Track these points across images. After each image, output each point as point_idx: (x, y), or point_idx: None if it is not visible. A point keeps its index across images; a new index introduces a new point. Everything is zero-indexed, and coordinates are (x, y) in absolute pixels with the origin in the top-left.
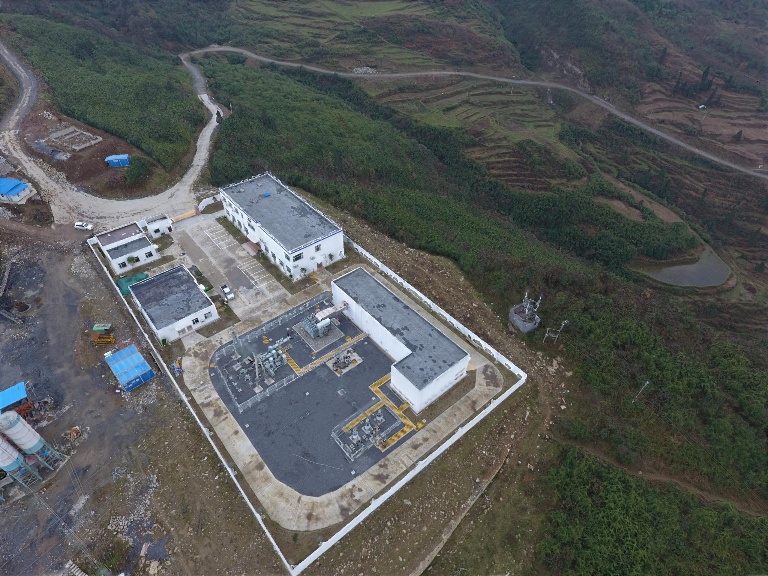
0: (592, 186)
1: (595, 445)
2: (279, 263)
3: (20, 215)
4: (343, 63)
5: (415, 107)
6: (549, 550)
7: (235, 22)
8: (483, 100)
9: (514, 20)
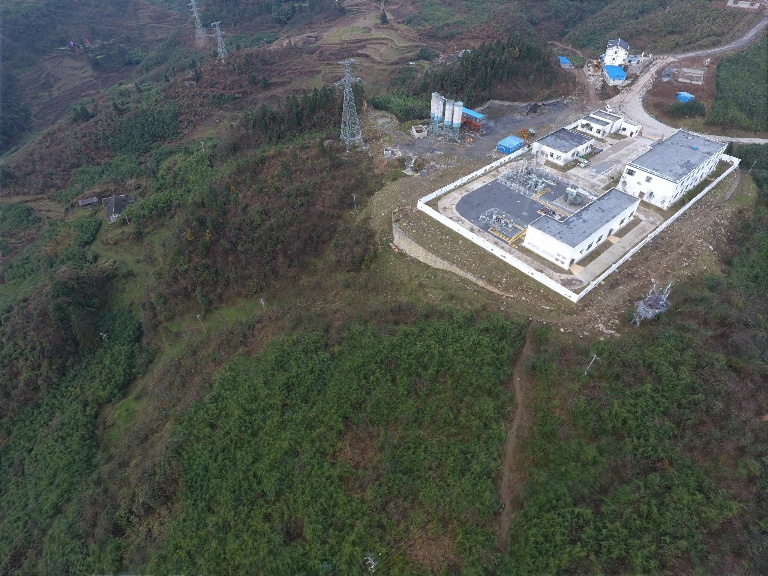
0: None
1: (534, 349)
2: None
3: None
4: None
5: None
6: (446, 308)
7: None
8: None
9: None
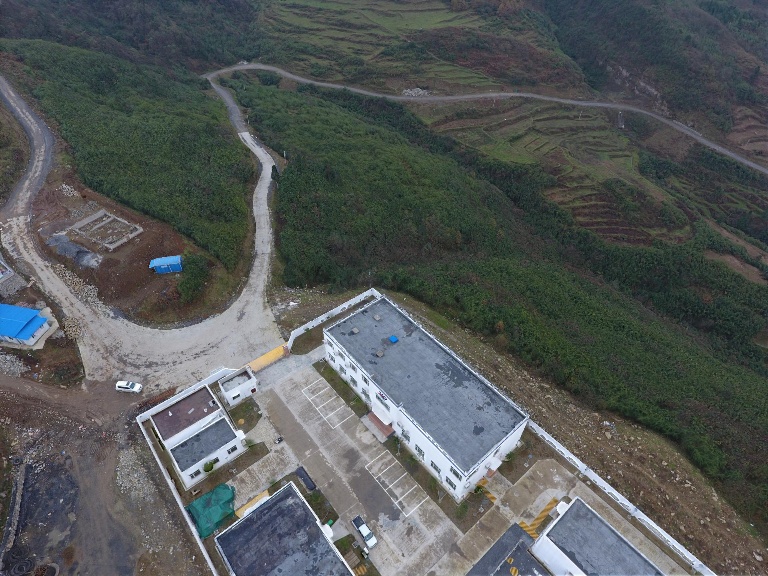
0: (701, 239)
1: None
2: (430, 464)
3: (36, 366)
4: (391, 84)
5: (478, 137)
6: None
7: (265, 35)
8: (550, 126)
9: (571, 31)
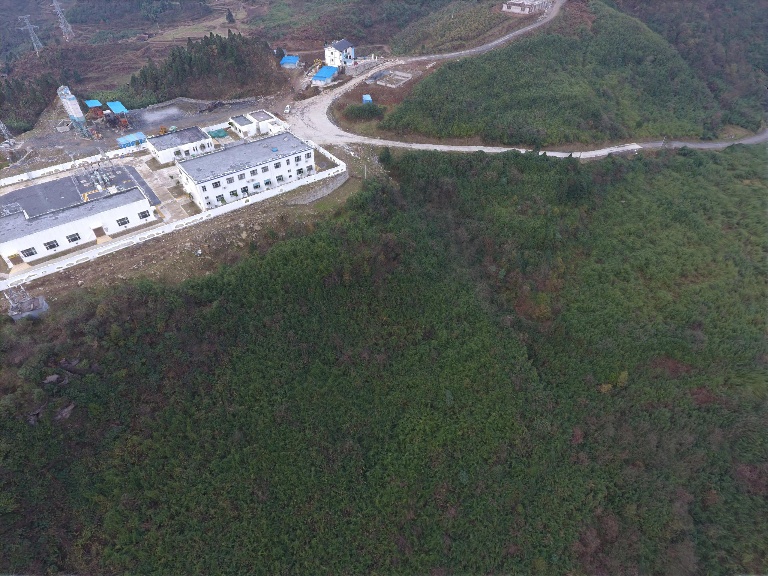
0: None
1: None
2: None
3: None
4: None
5: None
6: None
7: None
8: None
9: None
